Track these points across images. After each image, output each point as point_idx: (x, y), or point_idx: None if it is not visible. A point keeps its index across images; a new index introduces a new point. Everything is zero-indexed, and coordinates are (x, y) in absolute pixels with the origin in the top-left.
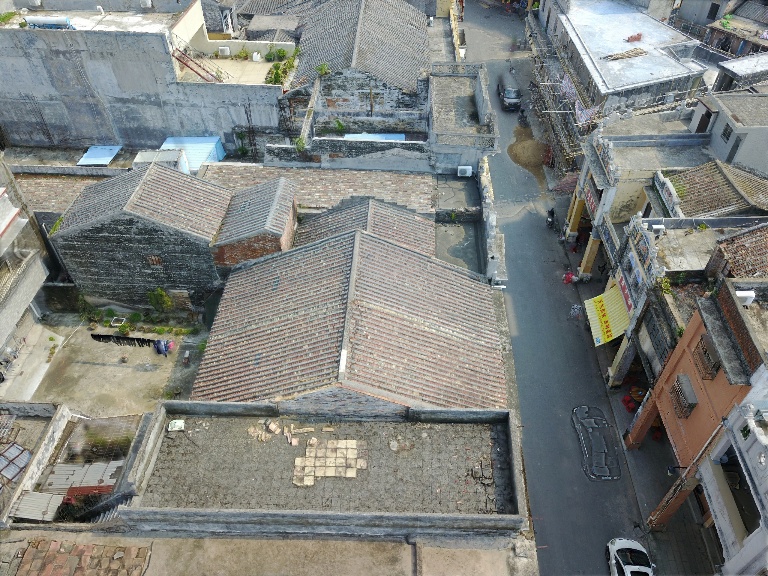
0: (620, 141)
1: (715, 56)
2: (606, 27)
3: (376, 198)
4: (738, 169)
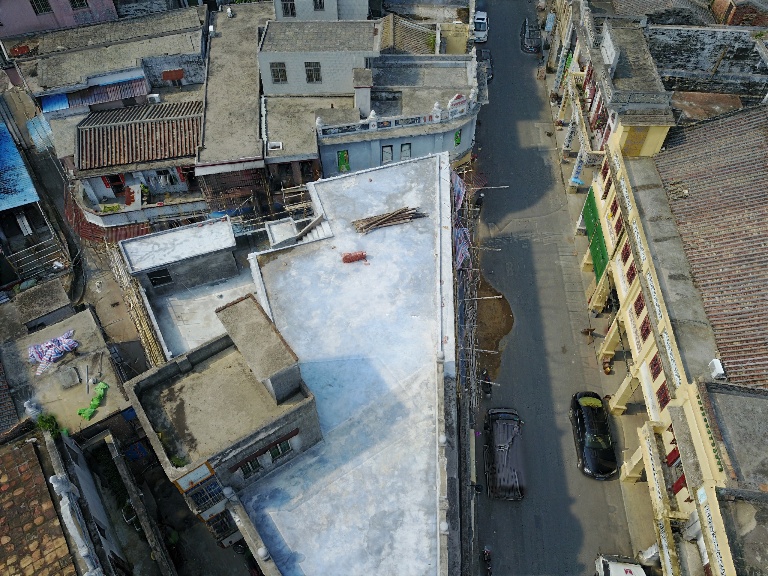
0: None
1: None
2: (381, 306)
3: (671, 8)
4: None
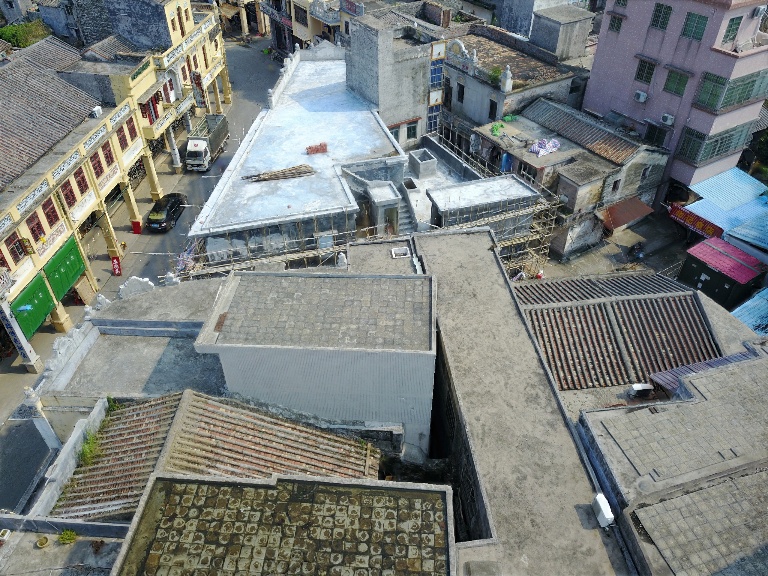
0: (121, 327)
1: (468, 172)
2: (301, 130)
3: None
4: (231, 405)
